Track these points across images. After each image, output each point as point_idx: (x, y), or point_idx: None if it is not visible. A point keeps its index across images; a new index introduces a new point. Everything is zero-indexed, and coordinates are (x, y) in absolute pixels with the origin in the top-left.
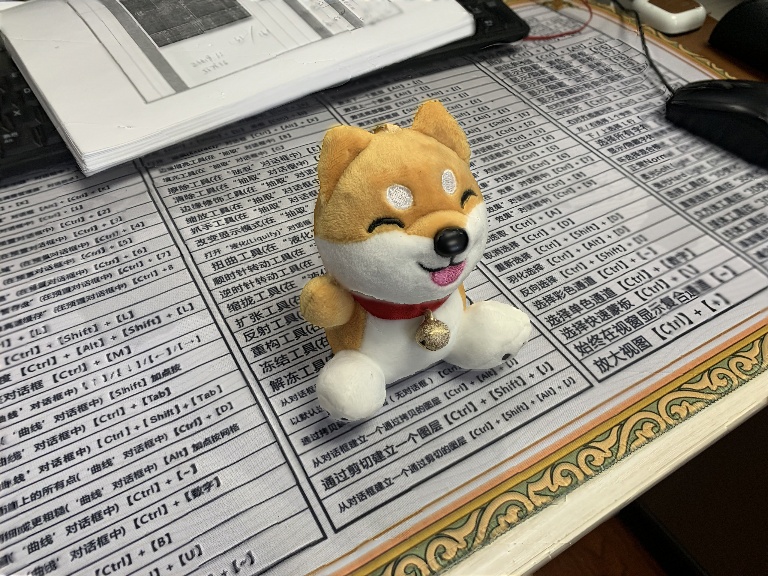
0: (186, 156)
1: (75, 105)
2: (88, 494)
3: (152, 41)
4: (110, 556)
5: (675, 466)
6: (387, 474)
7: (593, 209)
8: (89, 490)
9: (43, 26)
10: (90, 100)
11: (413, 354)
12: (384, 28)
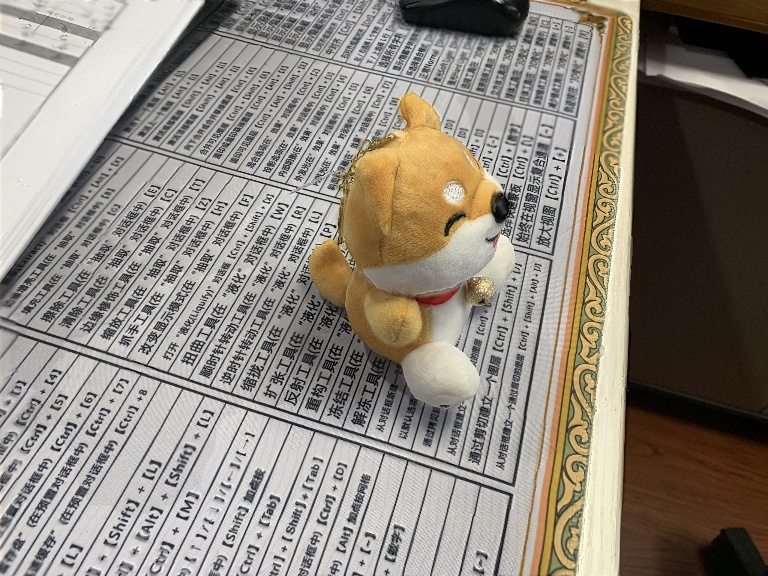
0: (19, 272)
1: None
2: None
3: None
4: None
5: (631, 281)
6: (503, 419)
7: None
8: None
9: None
10: None
11: (465, 317)
12: (122, 29)
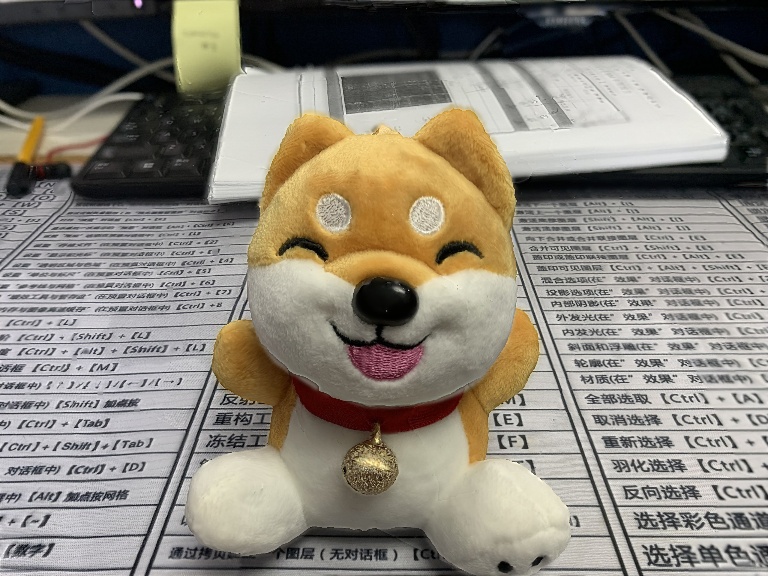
0: None
1: (241, 144)
2: None
3: (344, 109)
4: None
5: None
6: None
7: None
8: None
9: (267, 87)
10: (256, 143)
11: (348, 490)
12: (597, 133)
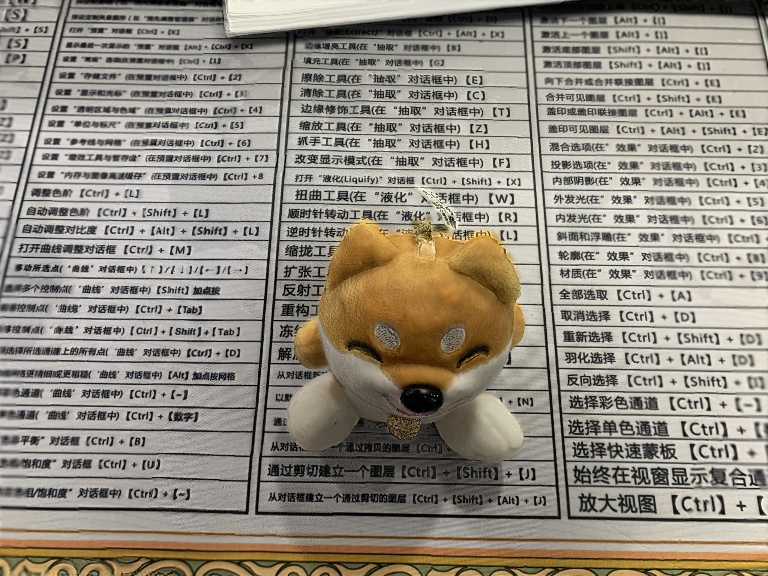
0: (340, 35)
1: None
2: (107, 371)
3: None
4: (101, 431)
5: None
6: (322, 491)
7: (733, 314)
8: (109, 368)
9: None
10: None
11: None
12: None
